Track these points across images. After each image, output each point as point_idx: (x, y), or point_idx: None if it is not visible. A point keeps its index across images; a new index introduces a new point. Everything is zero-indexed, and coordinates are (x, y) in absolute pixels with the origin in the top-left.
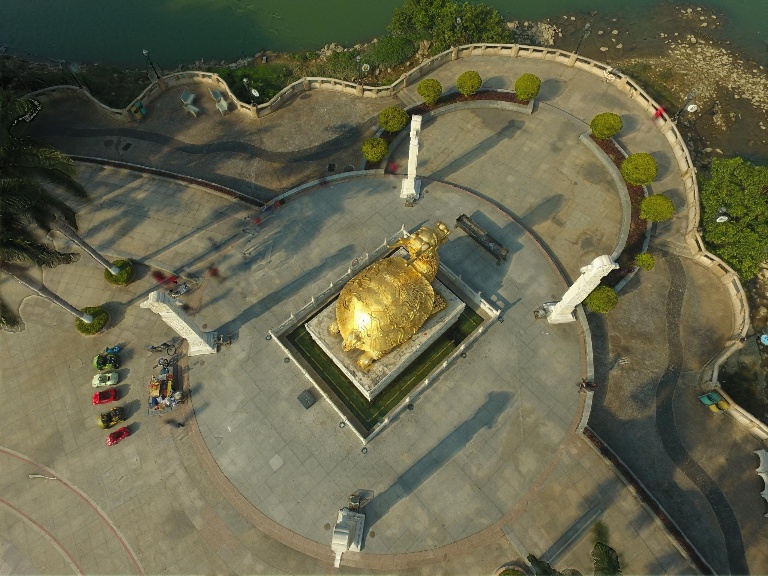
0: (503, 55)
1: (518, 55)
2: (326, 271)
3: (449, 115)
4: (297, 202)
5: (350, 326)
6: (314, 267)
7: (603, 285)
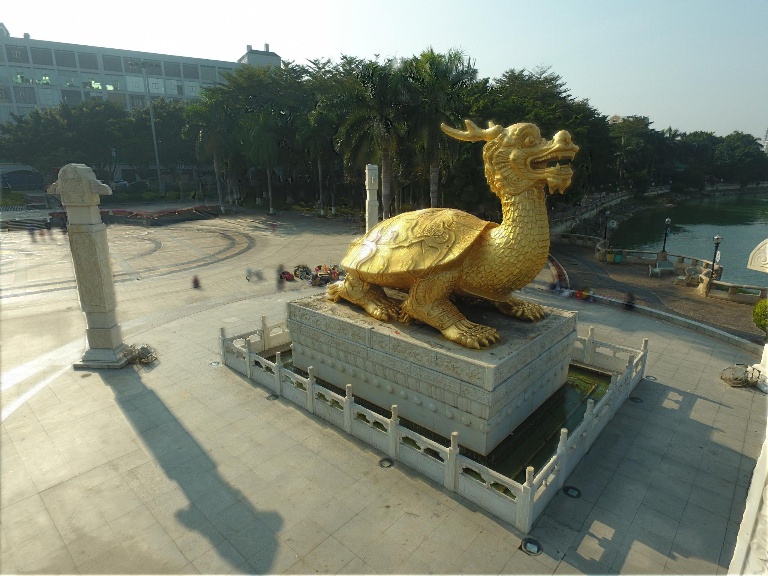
0: None
1: None
2: None
3: None
4: (597, 306)
5: None
6: None
7: None
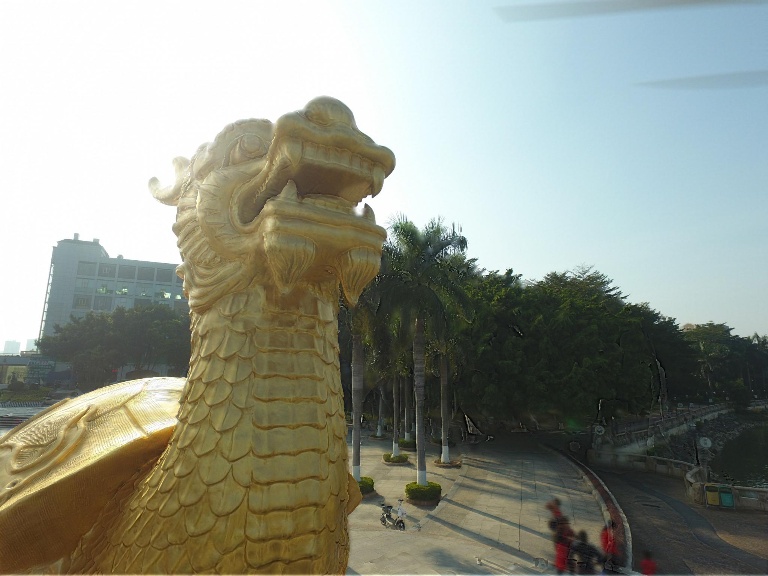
0: None
1: None
2: None
3: None
4: None
5: None
6: None
7: None
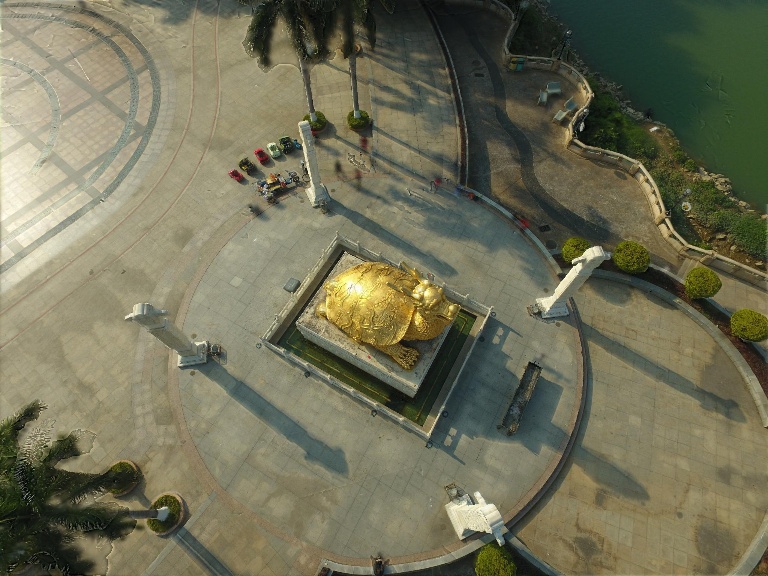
0: None
1: None
2: (418, 259)
3: (690, 322)
4: (482, 210)
5: (341, 277)
6: (419, 248)
7: (527, 574)
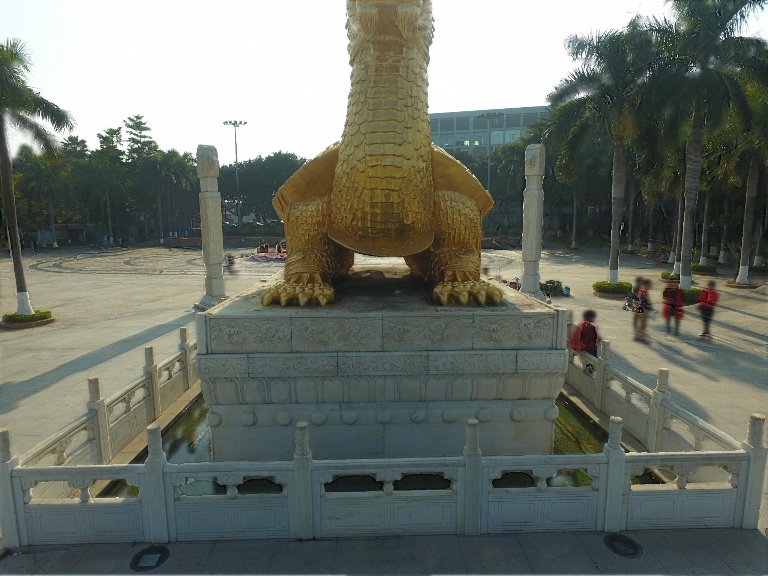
0: None
1: None
2: None
3: None
4: None
5: None
6: (633, 362)
7: None
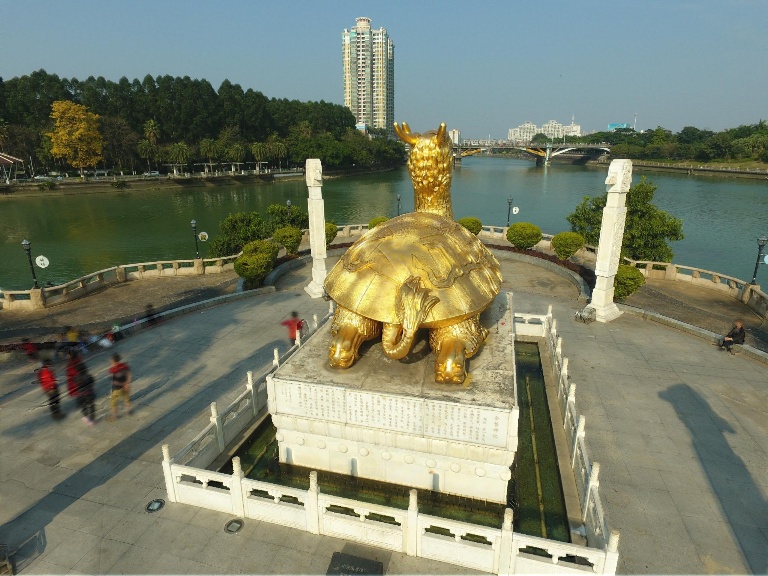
0: (337, 237)
1: (350, 235)
2: None
3: None
4: (148, 333)
5: (390, 282)
6: (219, 377)
7: None
